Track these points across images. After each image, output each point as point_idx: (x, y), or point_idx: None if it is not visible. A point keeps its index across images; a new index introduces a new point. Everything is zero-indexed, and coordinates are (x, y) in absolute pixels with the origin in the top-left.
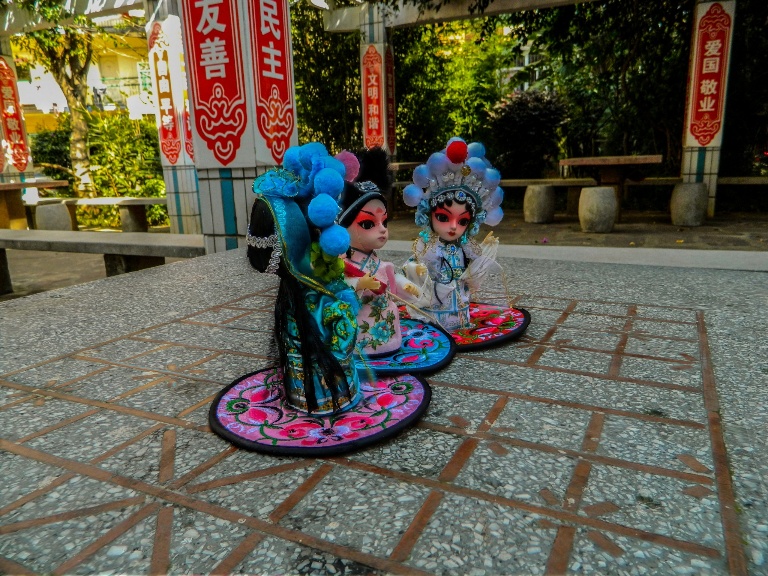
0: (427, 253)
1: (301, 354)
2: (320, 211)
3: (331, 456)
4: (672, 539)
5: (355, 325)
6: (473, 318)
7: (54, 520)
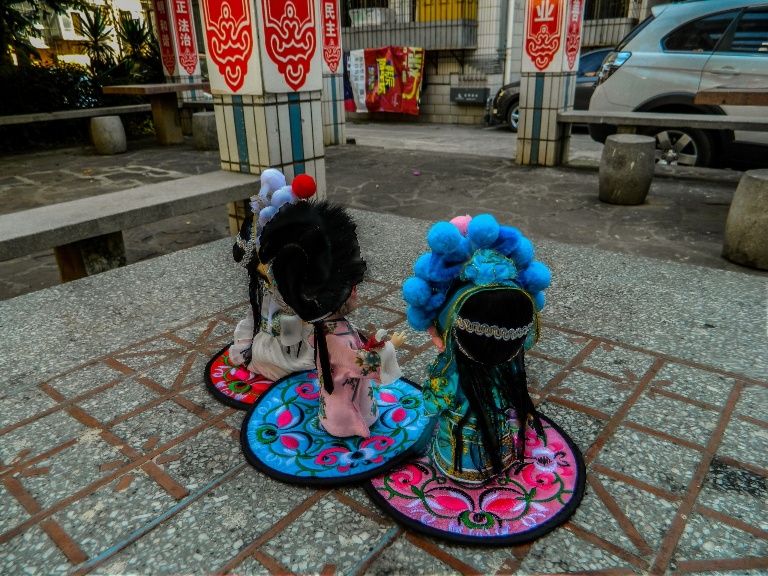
0: None
1: None
2: None
3: None
4: None
5: None
6: None
7: None
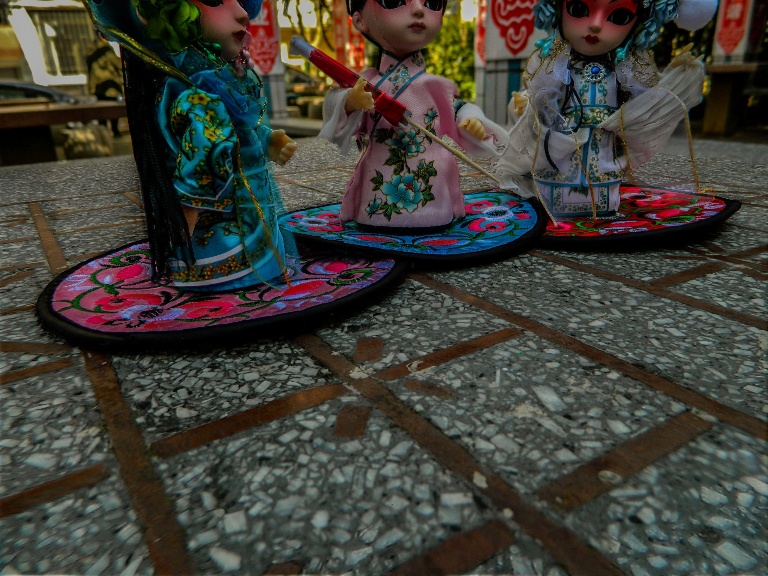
0: (539, 75)
1: None
2: None
3: (93, 348)
4: None
5: (221, 137)
6: (634, 208)
7: None
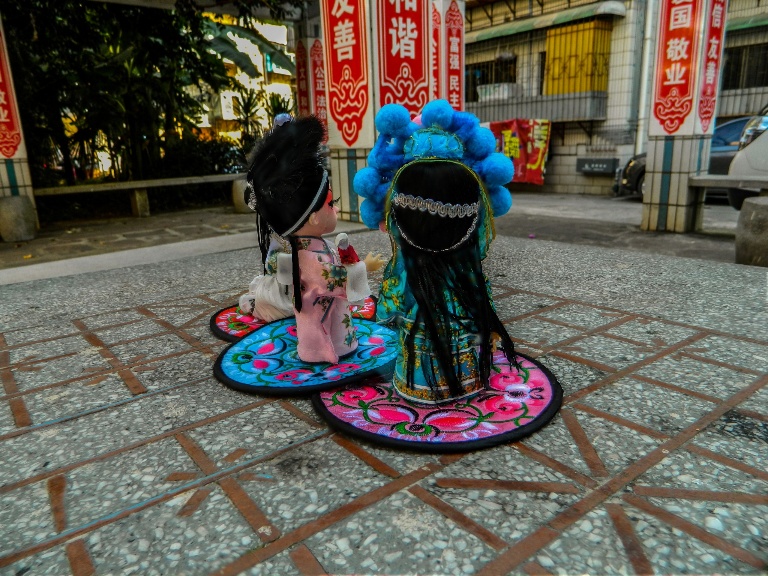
0: None
1: (483, 328)
2: (511, 168)
3: (562, 400)
4: None
5: None
6: None
7: (650, 575)
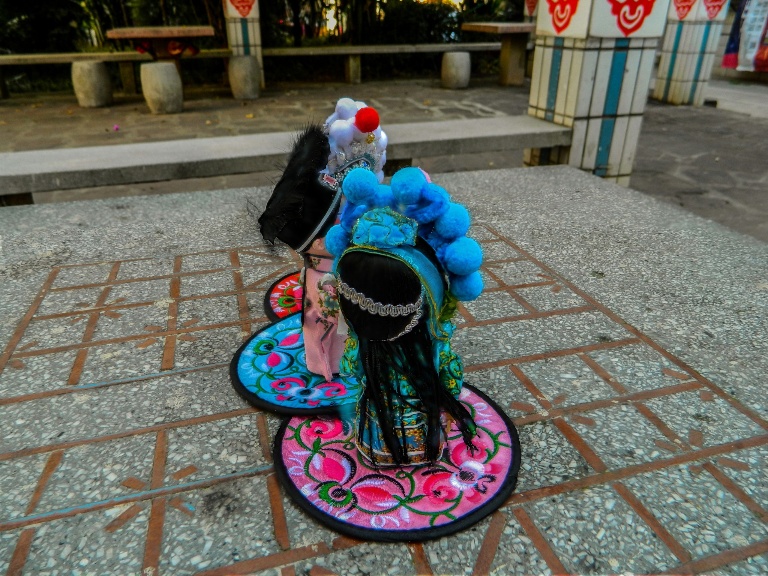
0: None
1: (429, 413)
2: (477, 261)
3: (507, 499)
4: (746, 439)
5: None
6: None
7: None
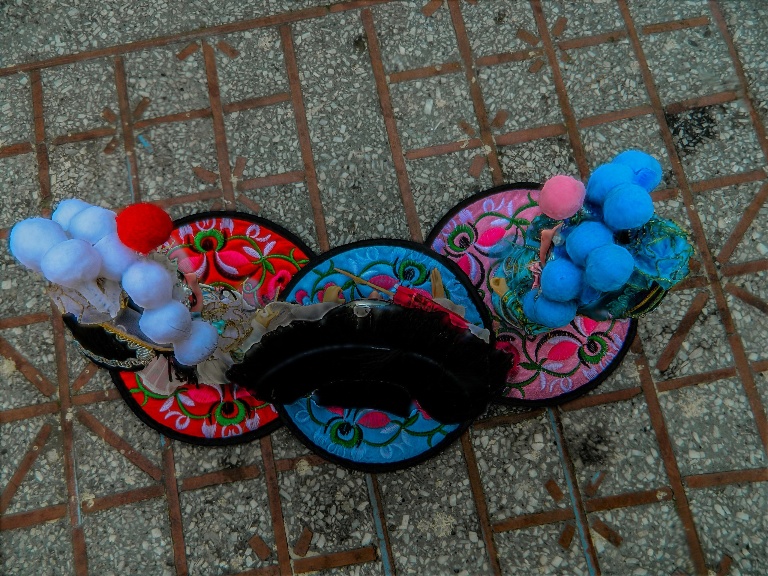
0: None
1: None
2: None
3: None
4: None
5: None
6: None
7: None
